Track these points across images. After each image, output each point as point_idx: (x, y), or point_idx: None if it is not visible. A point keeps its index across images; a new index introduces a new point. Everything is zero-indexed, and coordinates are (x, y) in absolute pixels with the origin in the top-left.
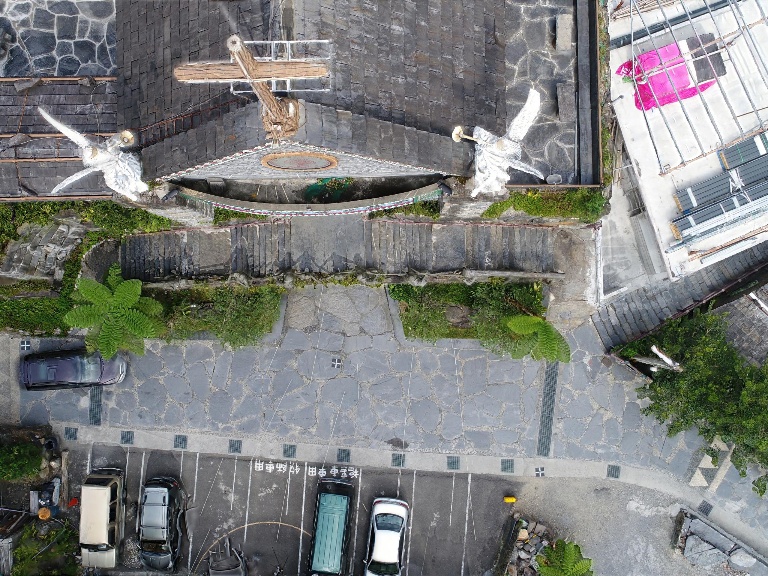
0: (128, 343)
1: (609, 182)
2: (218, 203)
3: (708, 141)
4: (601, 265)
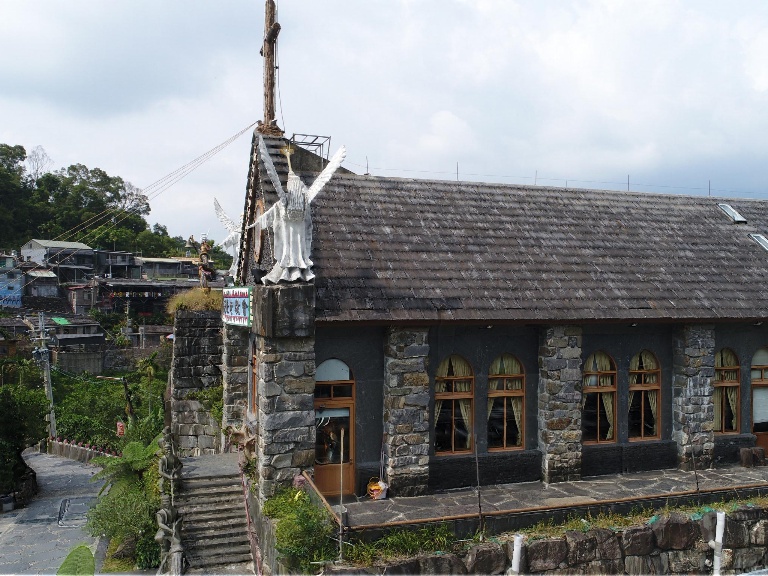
0: None
1: (361, 557)
2: None
3: None
4: None
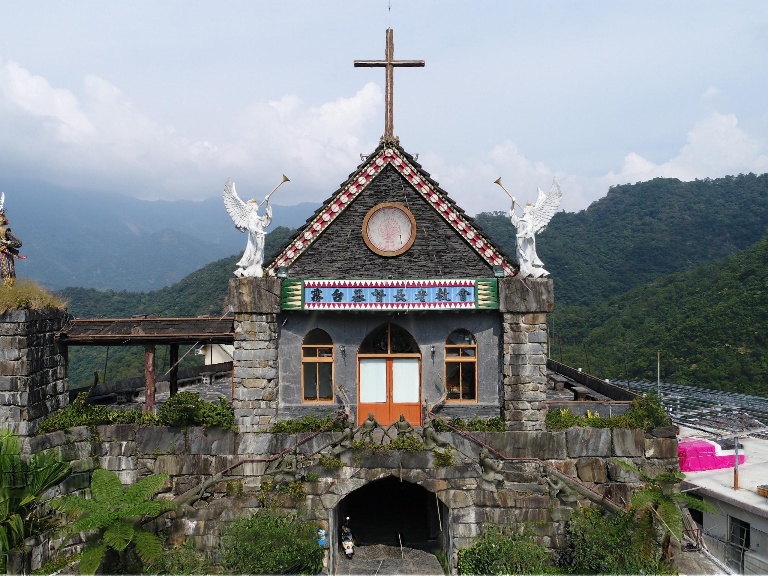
0: (112, 532)
1: None
2: (315, 281)
3: (765, 479)
4: (727, 568)
